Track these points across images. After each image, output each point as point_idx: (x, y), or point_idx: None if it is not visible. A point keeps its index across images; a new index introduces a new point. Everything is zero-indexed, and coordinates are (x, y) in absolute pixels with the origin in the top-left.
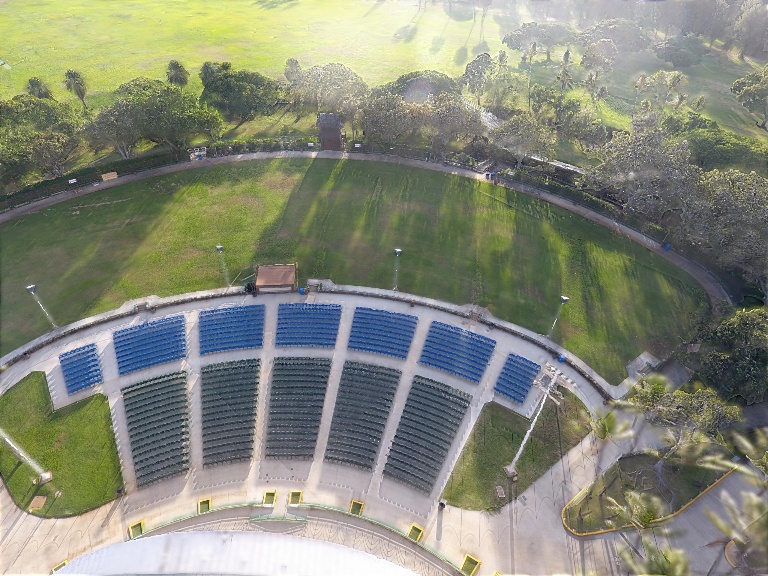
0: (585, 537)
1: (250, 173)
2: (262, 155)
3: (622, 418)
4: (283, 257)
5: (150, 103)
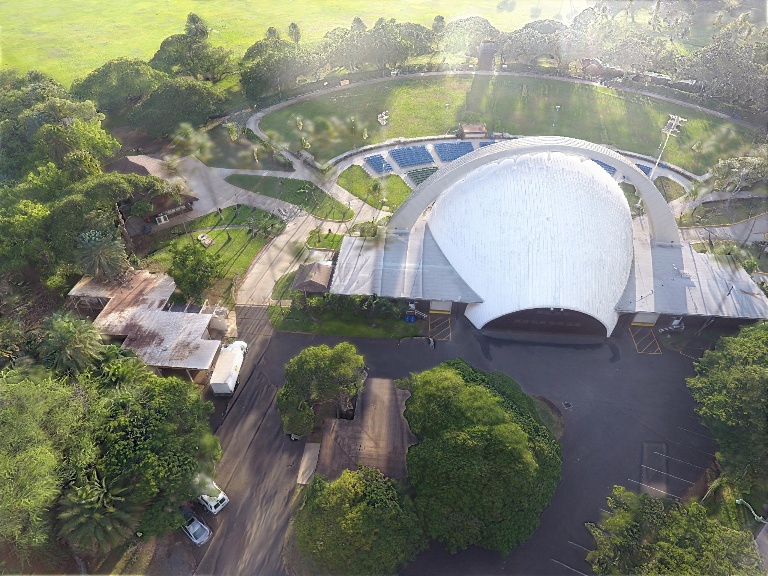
0: (684, 228)
1: (434, 82)
2: (438, 73)
3: (704, 190)
4: (474, 121)
5: (377, 32)
